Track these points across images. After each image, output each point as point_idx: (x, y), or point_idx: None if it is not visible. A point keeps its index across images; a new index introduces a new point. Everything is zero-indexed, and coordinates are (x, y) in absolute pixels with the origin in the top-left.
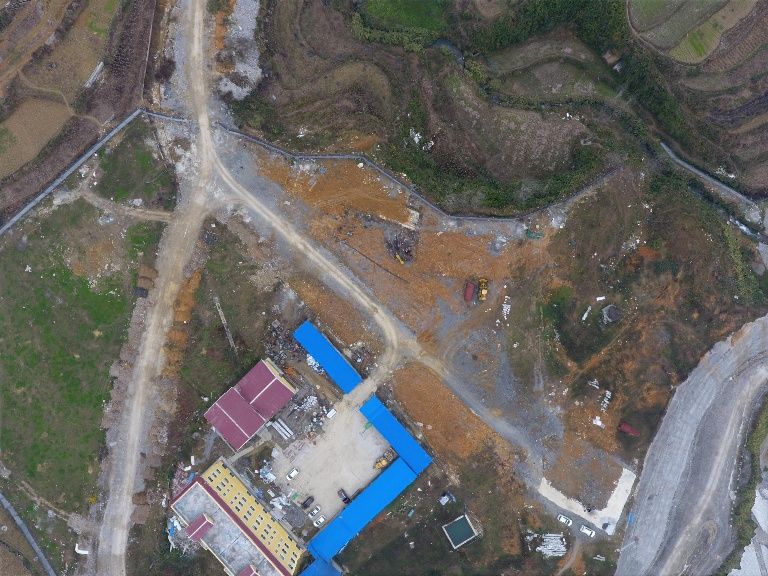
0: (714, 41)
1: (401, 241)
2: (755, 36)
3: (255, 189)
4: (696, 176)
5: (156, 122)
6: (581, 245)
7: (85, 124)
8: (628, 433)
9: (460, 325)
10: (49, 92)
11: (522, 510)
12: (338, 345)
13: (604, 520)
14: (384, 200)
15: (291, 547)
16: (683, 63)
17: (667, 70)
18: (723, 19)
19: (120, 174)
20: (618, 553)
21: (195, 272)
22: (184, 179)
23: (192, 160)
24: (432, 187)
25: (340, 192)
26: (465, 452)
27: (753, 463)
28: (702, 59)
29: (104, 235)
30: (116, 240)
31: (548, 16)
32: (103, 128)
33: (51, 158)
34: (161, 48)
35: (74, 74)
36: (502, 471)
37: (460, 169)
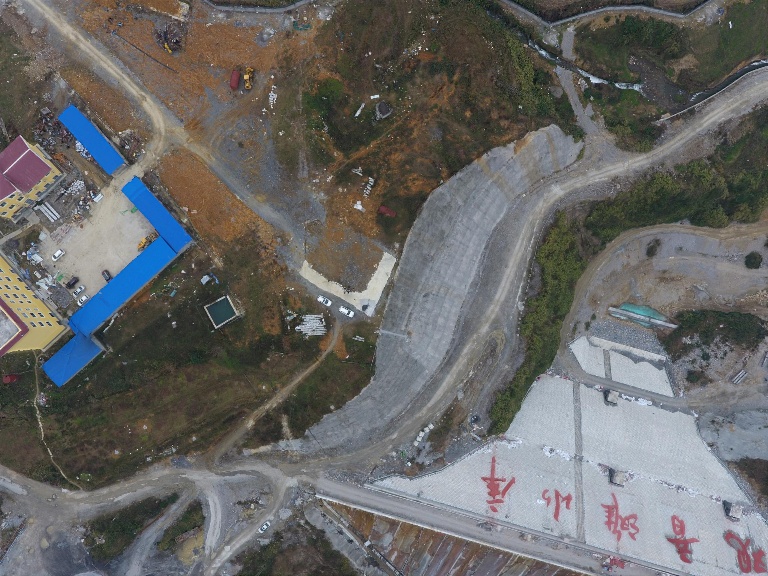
0: None
1: (171, 32)
2: None
3: None
4: None
5: None
6: (351, 40)
7: None
8: (385, 214)
9: (227, 113)
10: None
11: (283, 292)
12: (107, 132)
13: (364, 302)
14: None
15: (47, 318)
16: None
17: None
18: None
19: None
20: (377, 334)
21: None
22: None
23: None
24: None
25: None
26: (229, 236)
27: (543, 276)
28: None
29: None
30: None
31: None
32: None
33: None
34: None
35: None
36: (265, 254)
37: None
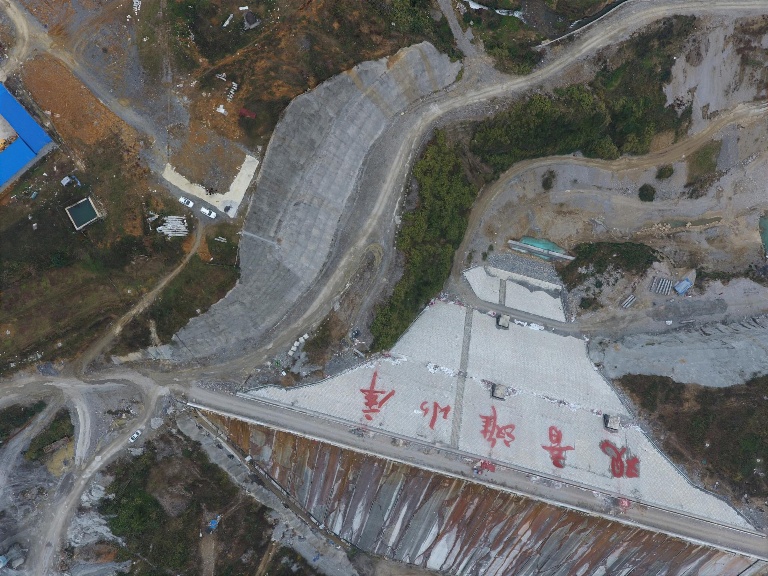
0: None
1: None
2: None
3: None
4: None
5: None
6: None
7: None
8: (245, 116)
9: (91, 20)
10: None
11: (146, 193)
12: None
13: (226, 203)
14: None
15: None
16: None
17: None
18: None
19: None
20: (240, 235)
21: None
22: None
23: None
24: None
25: None
26: (91, 139)
27: (420, 191)
28: None
29: None
30: None
31: None
32: None
33: None
34: None
35: None
36: (127, 157)
37: None
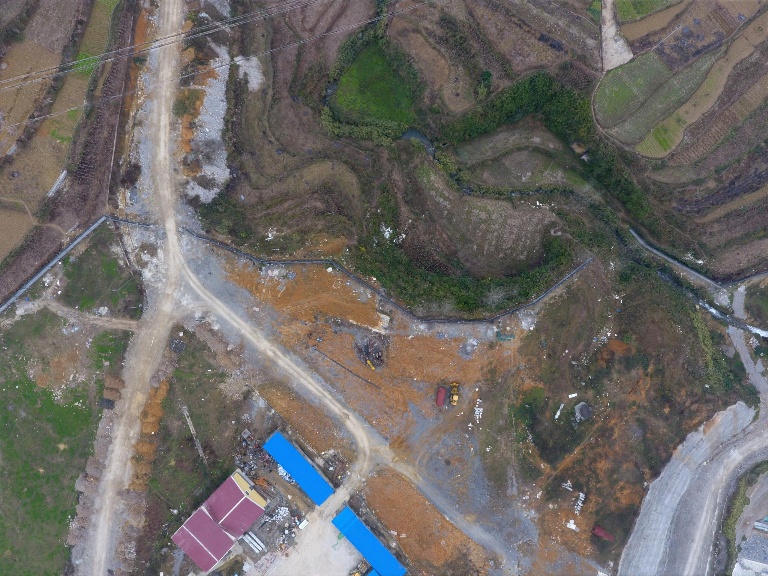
0: (678, 136)
1: (372, 346)
2: (717, 129)
3: (223, 295)
4: (665, 261)
5: (122, 228)
6: (552, 345)
7: (48, 232)
8: (602, 537)
9: (432, 430)
10: (11, 202)
11: None
12: (309, 453)
13: None
14: (354, 305)
15: None
16: (648, 158)
17: (633, 164)
18: (686, 114)
19: (85, 282)
20: None
21: (163, 382)
22: (151, 286)
23: (159, 266)
24: (402, 288)
25: (309, 297)
26: (440, 560)
27: (729, 549)
28: (666, 154)
29: (69, 345)
30: (81, 350)
31: (516, 108)
32: (67, 236)
33: (13, 268)
34: (126, 152)
35: (36, 183)
36: None
37: (431, 262)
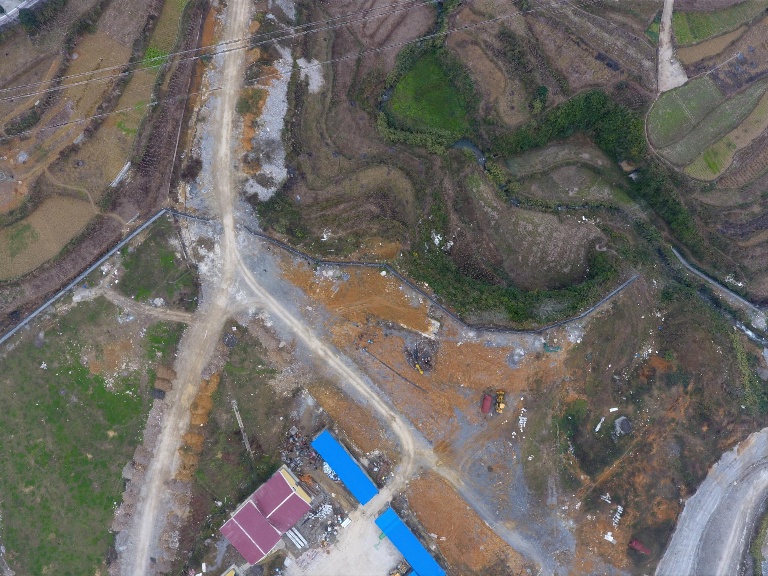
0: (727, 160)
1: (421, 350)
2: (766, 155)
3: (277, 293)
4: (705, 282)
5: (180, 221)
6: (596, 358)
7: (109, 222)
8: (639, 551)
9: (477, 436)
10: (74, 190)
11: None
12: (355, 453)
13: None
14: (405, 309)
15: None
16: (697, 180)
17: (682, 185)
18: (736, 139)
19: (142, 272)
20: None
21: (214, 375)
22: (206, 280)
23: (215, 261)
24: (452, 295)
25: (362, 299)
26: (478, 565)
27: (755, 569)
28: (715, 177)
29: (123, 334)
30: (135, 339)
31: (568, 124)
32: (127, 227)
33: (73, 255)
34: (188, 147)
35: (100, 173)
36: None
37: (478, 271)
